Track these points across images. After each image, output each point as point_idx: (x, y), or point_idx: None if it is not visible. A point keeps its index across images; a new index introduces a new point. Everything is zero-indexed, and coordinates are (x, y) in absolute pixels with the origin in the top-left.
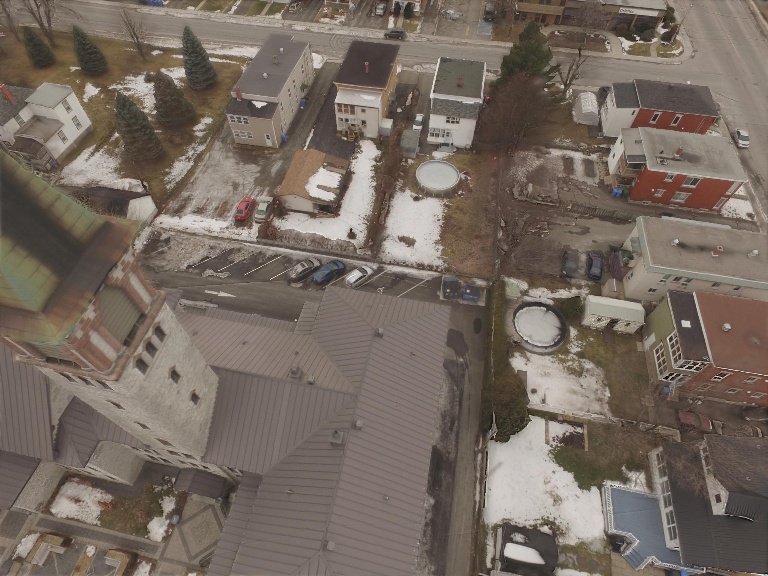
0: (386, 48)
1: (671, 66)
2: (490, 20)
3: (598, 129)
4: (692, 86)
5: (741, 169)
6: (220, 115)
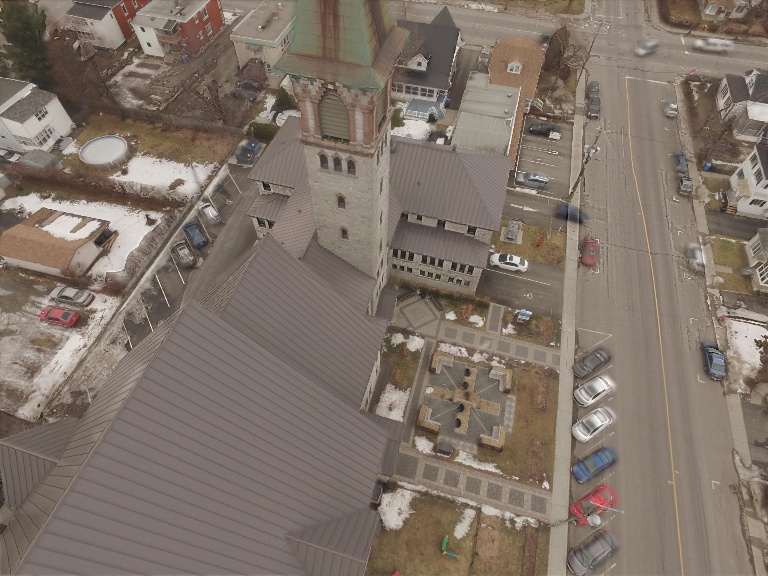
0: None
1: None
2: None
3: (103, 51)
4: None
5: None
6: None
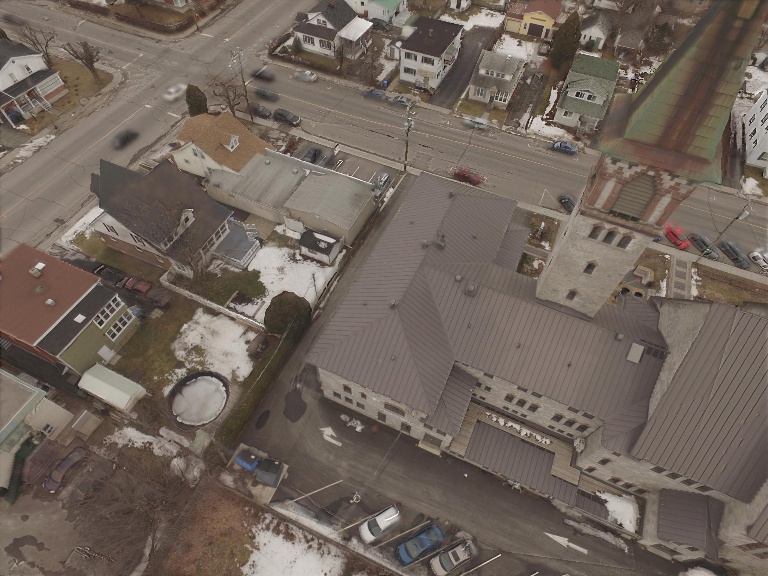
0: None
1: None
2: None
3: None
4: None
5: None
6: None
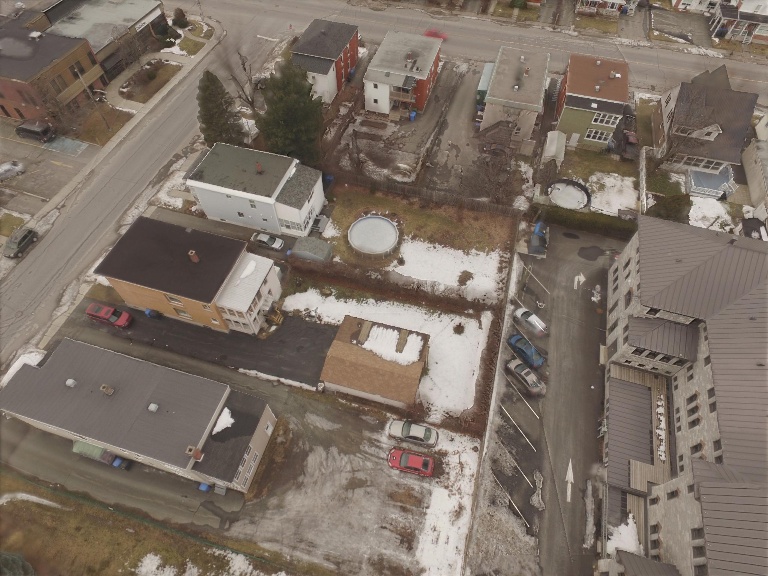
0: (138, 233)
1: (227, 37)
2: (54, 137)
3: None
4: (321, 23)
5: (429, 37)
6: (140, 539)
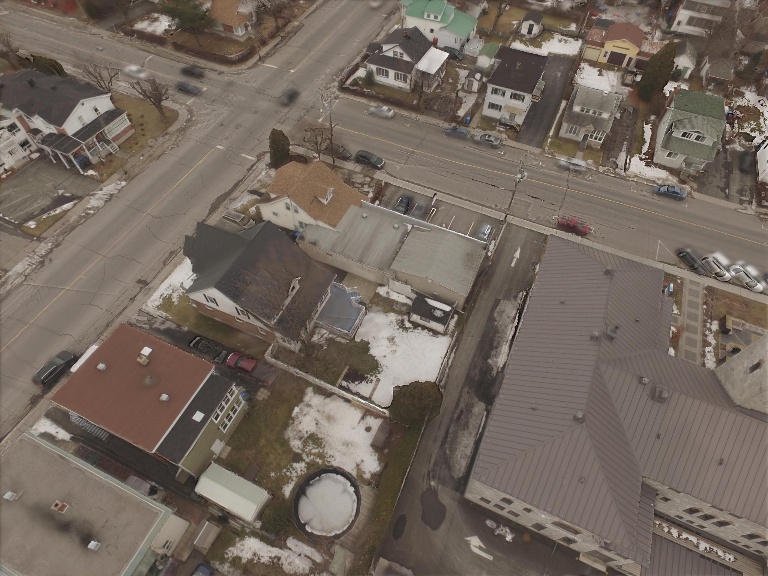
0: None
1: None
2: None
3: None
4: None
5: None
6: None
